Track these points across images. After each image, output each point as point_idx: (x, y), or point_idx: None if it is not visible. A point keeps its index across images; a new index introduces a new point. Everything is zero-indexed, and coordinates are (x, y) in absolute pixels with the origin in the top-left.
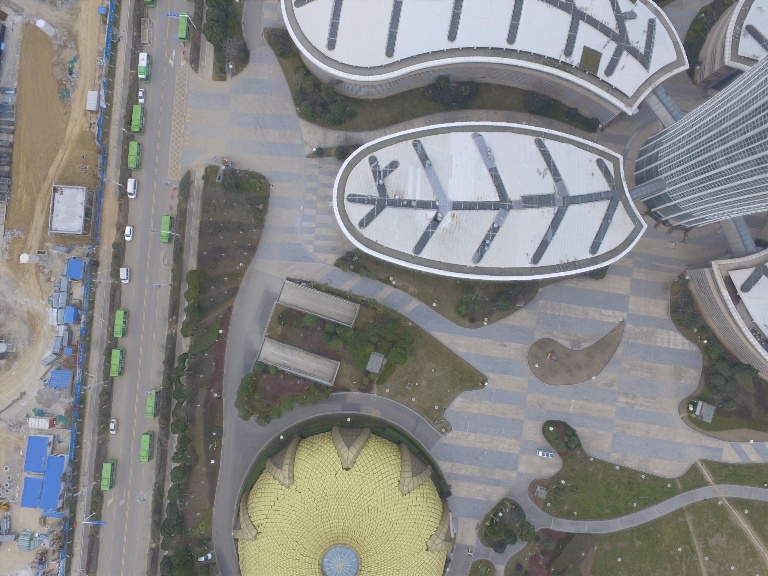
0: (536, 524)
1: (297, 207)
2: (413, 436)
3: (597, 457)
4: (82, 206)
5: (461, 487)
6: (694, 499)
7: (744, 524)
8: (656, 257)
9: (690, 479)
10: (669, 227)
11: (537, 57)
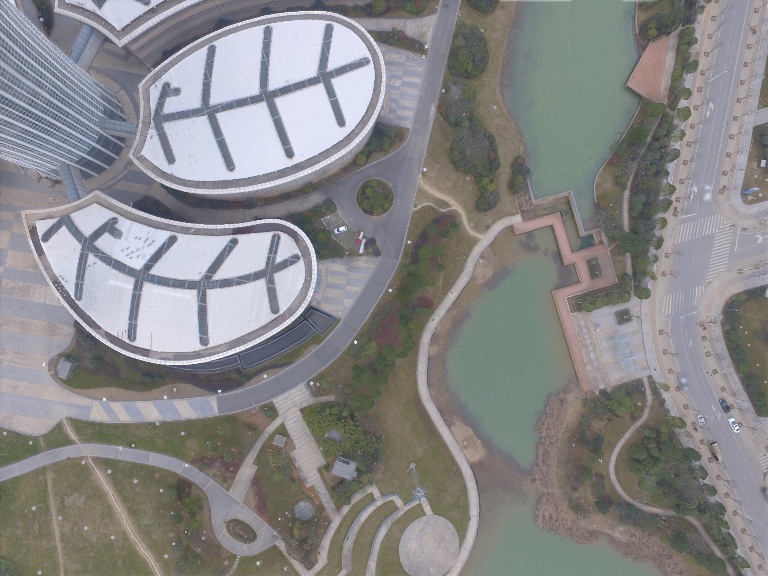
0: None
1: None
2: None
3: None
4: None
5: None
6: (58, 458)
7: (105, 484)
8: None
9: (53, 437)
10: (52, 181)
11: None
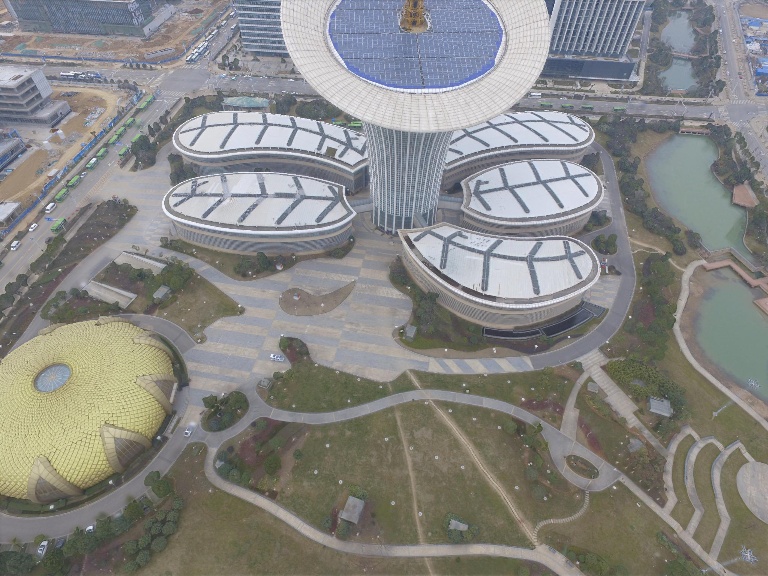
0: (257, 413)
1: (149, 220)
2: (173, 344)
3: (321, 364)
4: (13, 210)
5: (199, 381)
6: (403, 400)
7: (448, 421)
8: (382, 250)
9: (400, 383)
10: (391, 235)
11: (304, 152)
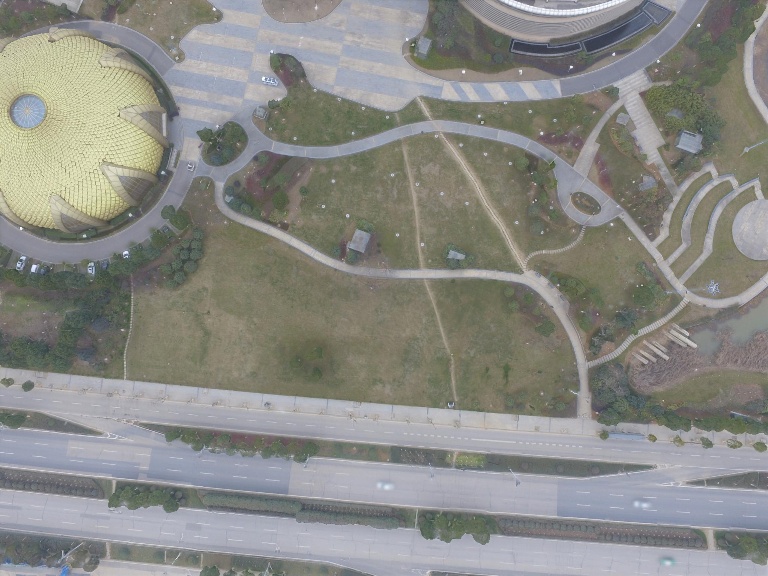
0: (257, 146)
1: None
2: (148, 62)
3: (321, 89)
4: None
5: (189, 110)
6: (412, 132)
7: (458, 156)
8: None
9: (408, 112)
10: None
11: None
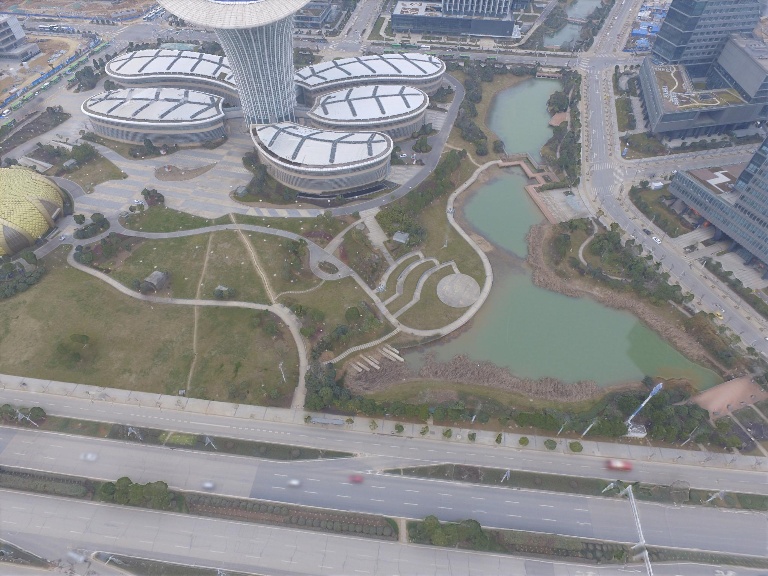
0: (114, 231)
1: None
2: (70, 193)
3: None
4: None
5: None
6: (220, 229)
7: (246, 240)
8: (246, 145)
9: (221, 219)
10: None
11: (203, 76)
